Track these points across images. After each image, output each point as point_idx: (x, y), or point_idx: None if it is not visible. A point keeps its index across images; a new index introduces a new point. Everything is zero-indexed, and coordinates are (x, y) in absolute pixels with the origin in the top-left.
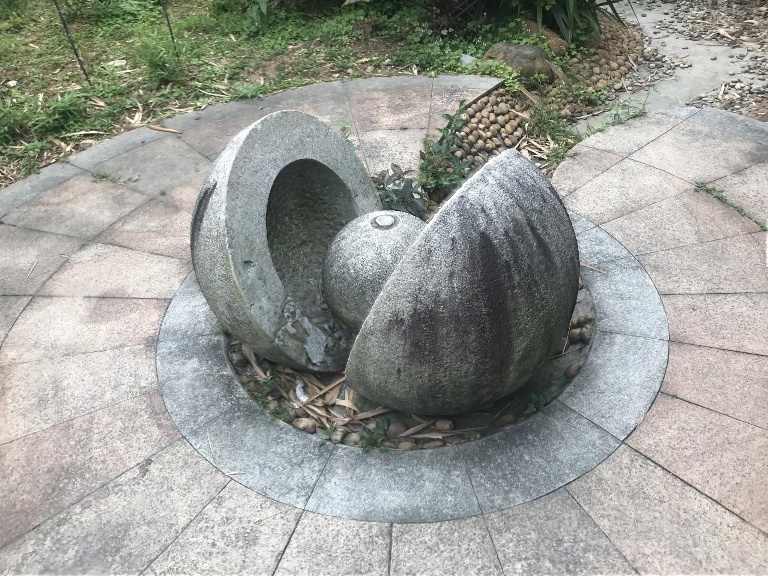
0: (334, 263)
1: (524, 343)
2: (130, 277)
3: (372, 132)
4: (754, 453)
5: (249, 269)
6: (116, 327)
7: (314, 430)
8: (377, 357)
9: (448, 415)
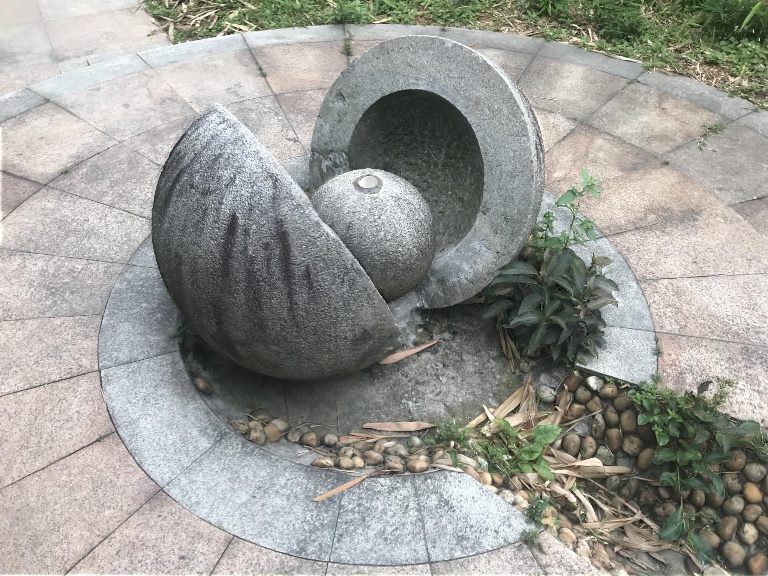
0: None
1: None
2: None
3: None
4: None
5: (341, 101)
6: None
7: None
8: None
9: None
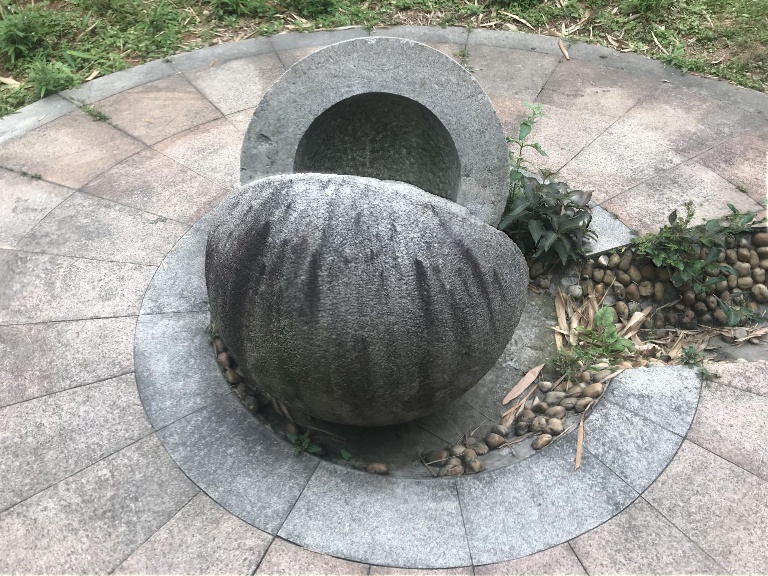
0: None
1: (255, 353)
2: None
3: (704, 168)
4: None
5: (264, 143)
6: None
7: None
8: None
9: None
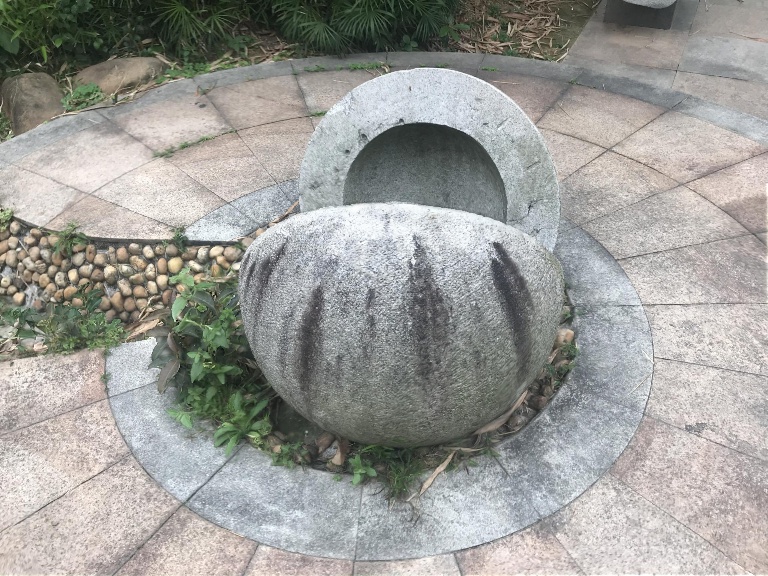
0: None
1: None
2: None
3: None
4: None
5: None
6: None
7: None
8: None
9: None
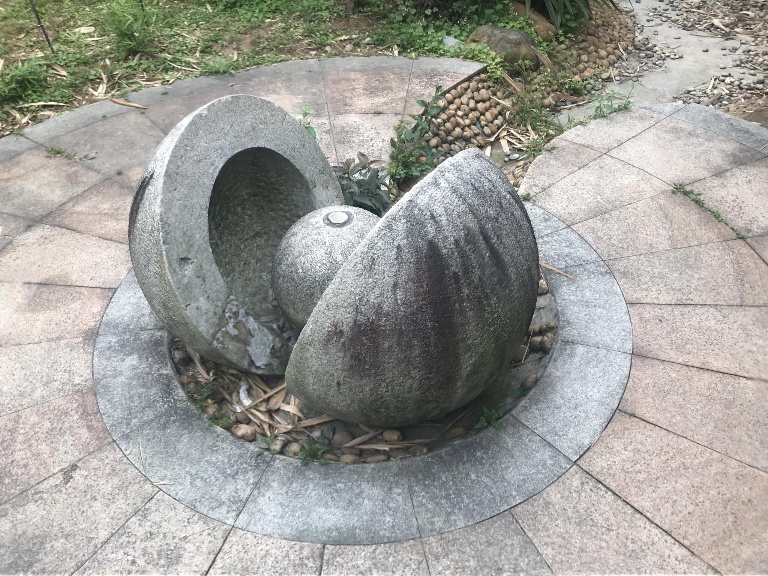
0: (282, 261)
1: (472, 359)
2: (75, 263)
3: (344, 115)
4: (710, 480)
5: (186, 266)
6: (55, 317)
7: (253, 438)
8: (315, 368)
9: (395, 426)
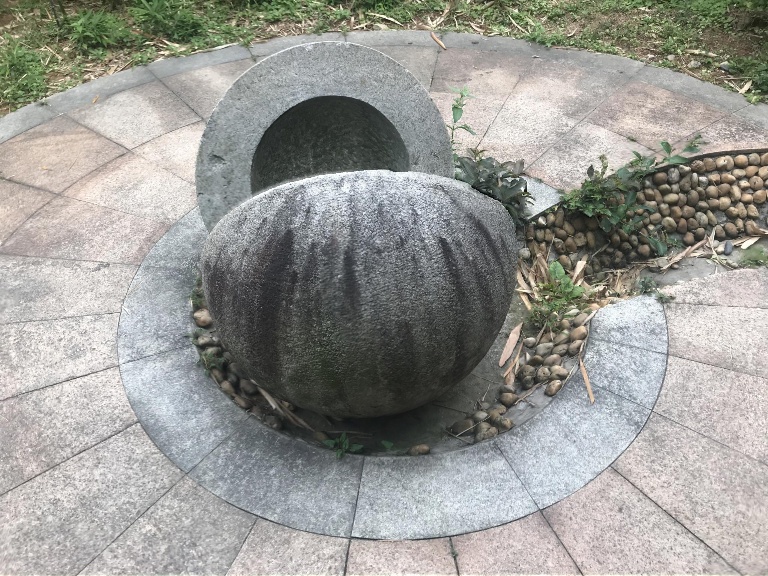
0: None
1: (293, 364)
2: None
3: (596, 127)
4: None
5: (218, 164)
6: None
7: (204, 325)
8: None
9: None
